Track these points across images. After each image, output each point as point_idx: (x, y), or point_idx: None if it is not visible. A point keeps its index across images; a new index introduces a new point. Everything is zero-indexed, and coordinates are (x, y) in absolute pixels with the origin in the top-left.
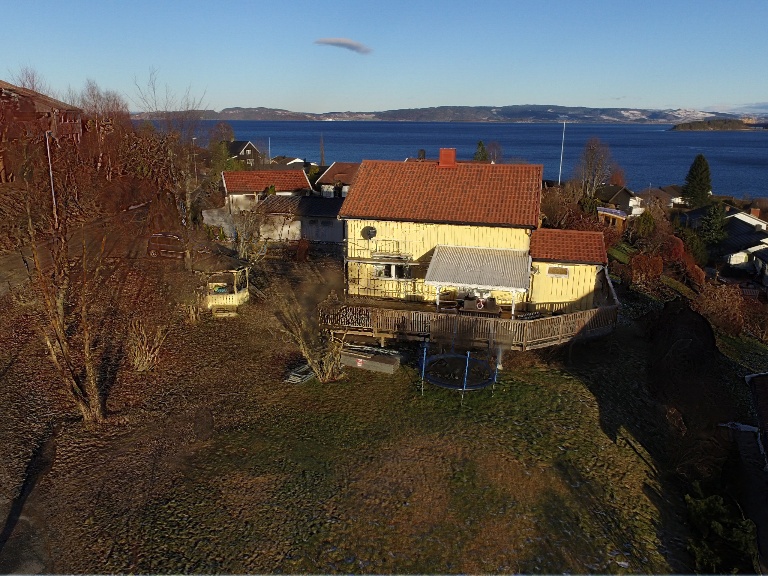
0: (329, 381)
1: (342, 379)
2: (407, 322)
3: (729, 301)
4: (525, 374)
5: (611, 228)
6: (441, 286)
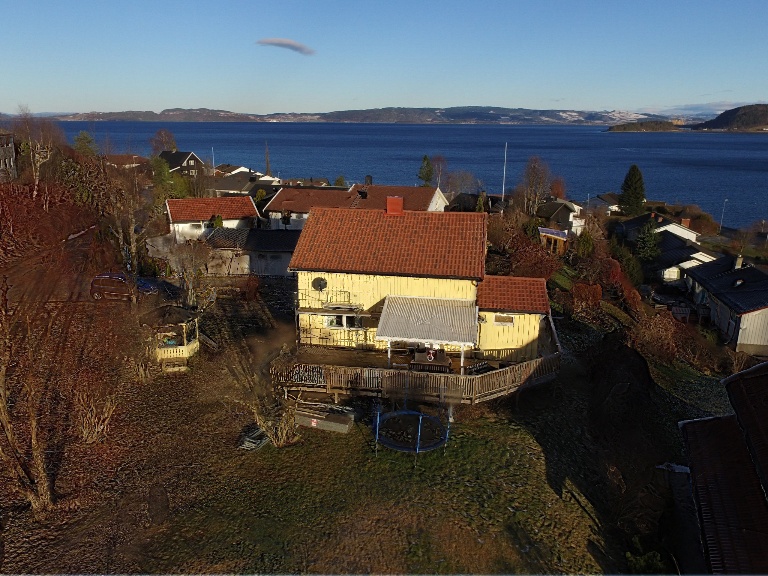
0: (284, 445)
1: (297, 442)
2: (360, 378)
3: (663, 331)
4: (475, 426)
5: (553, 256)
6: (392, 340)
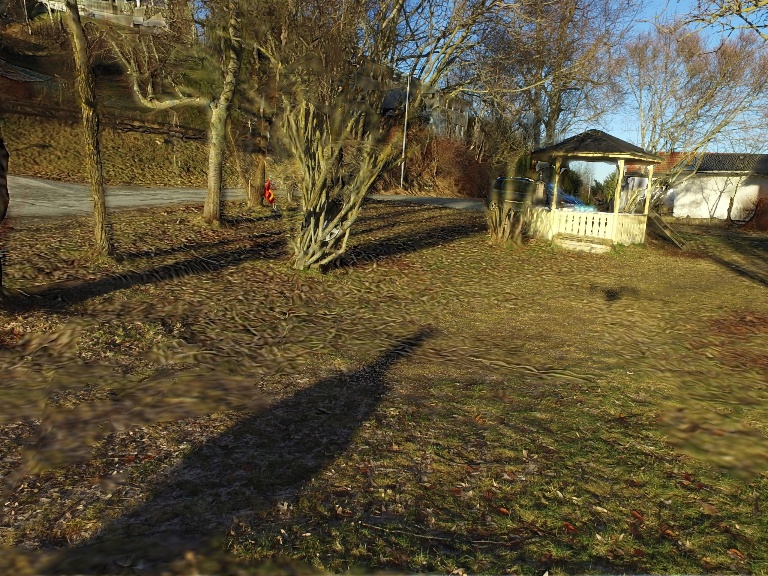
0: None
1: None
2: None
3: None
4: None
5: None
6: None
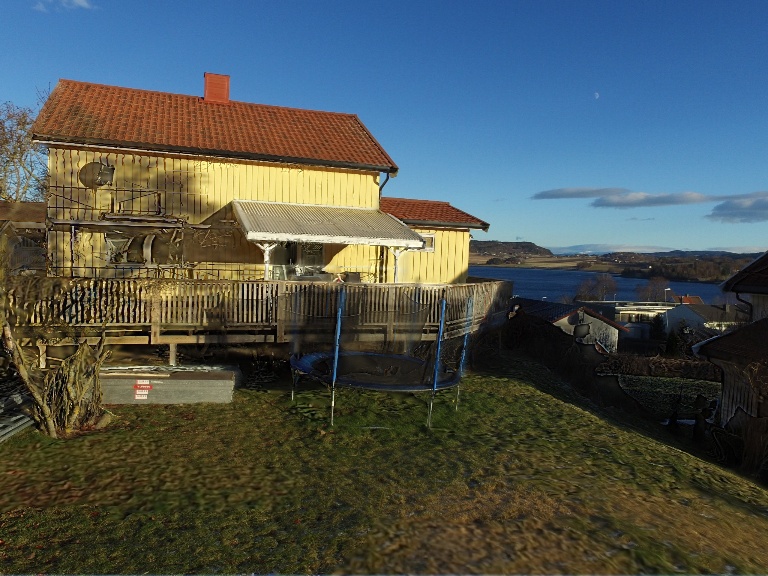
0: (76, 433)
1: (110, 426)
2: (229, 304)
3: None
4: None
5: None
6: (273, 246)
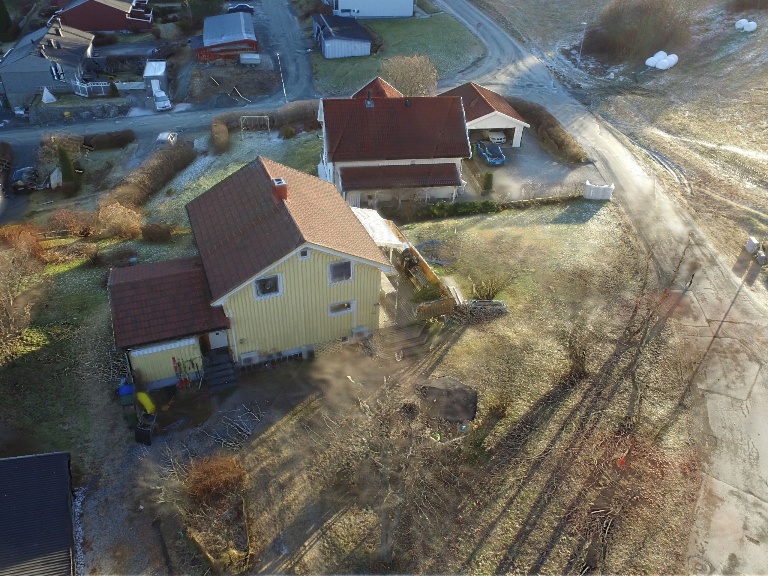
0: None
1: None
2: None
3: None
4: None
5: None
6: None
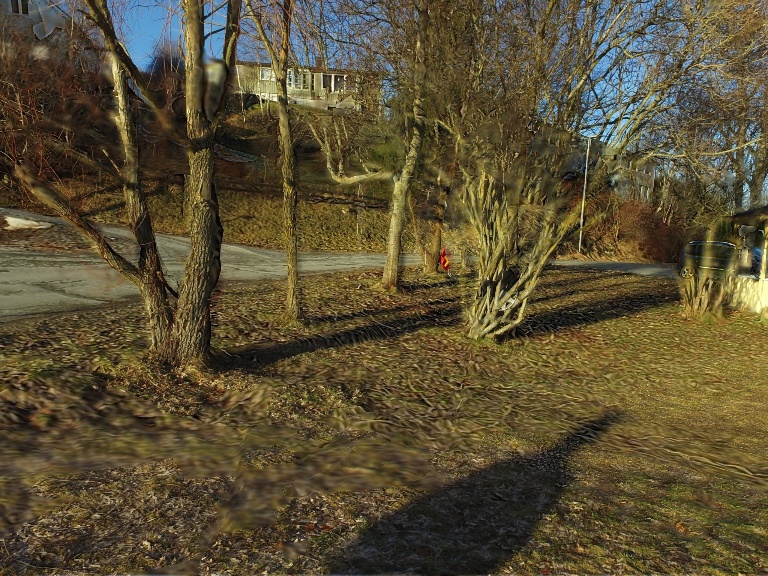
0: None
1: None
2: None
3: None
4: None
5: None
6: None
